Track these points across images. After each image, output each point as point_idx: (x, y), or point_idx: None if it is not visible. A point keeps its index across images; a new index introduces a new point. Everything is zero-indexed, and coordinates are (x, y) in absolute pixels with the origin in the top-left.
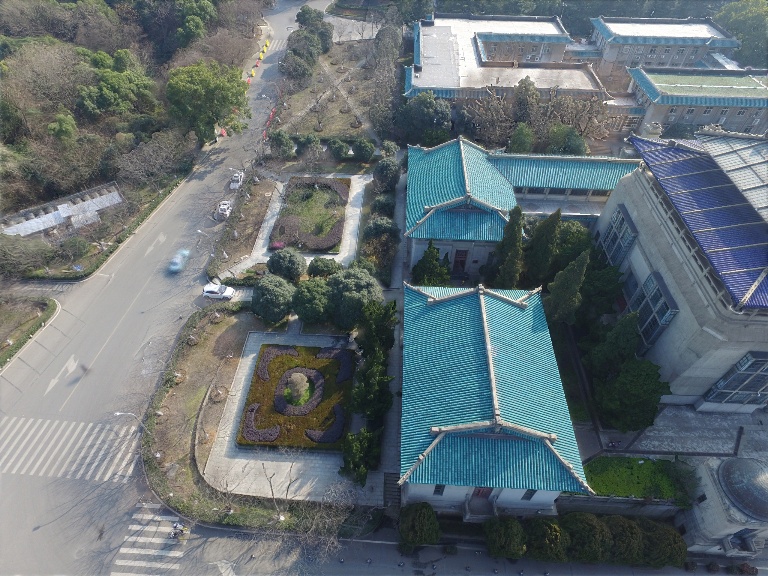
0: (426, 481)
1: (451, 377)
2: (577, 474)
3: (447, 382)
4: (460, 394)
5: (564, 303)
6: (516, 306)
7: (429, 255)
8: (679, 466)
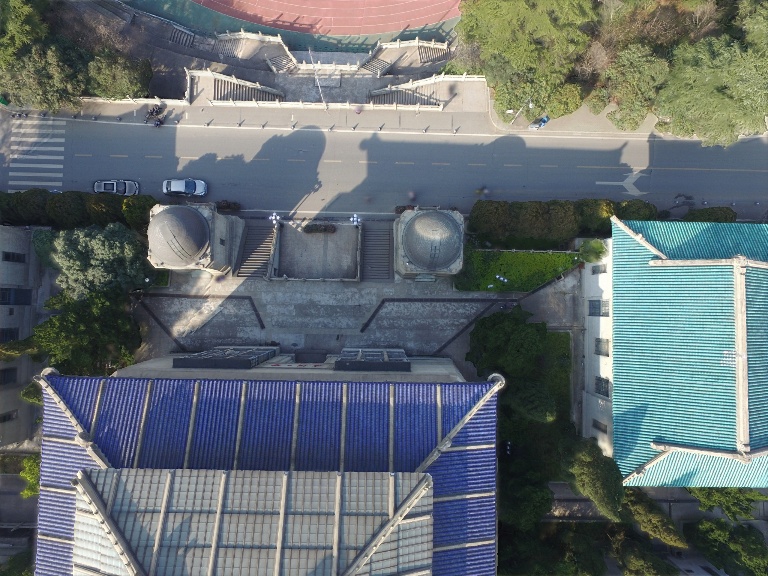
0: (767, 226)
1: (765, 328)
2: (625, 235)
3: (767, 323)
4: (760, 304)
5: (600, 455)
6: (671, 444)
7: (764, 554)
8: (468, 276)
